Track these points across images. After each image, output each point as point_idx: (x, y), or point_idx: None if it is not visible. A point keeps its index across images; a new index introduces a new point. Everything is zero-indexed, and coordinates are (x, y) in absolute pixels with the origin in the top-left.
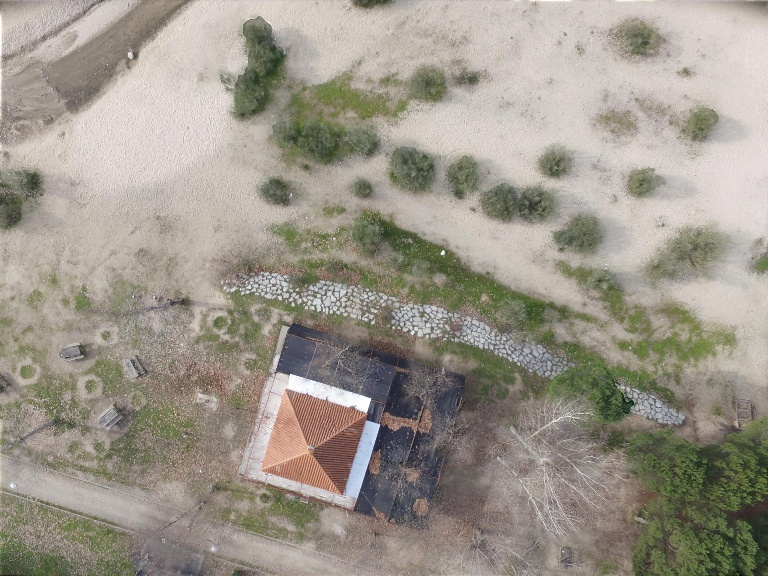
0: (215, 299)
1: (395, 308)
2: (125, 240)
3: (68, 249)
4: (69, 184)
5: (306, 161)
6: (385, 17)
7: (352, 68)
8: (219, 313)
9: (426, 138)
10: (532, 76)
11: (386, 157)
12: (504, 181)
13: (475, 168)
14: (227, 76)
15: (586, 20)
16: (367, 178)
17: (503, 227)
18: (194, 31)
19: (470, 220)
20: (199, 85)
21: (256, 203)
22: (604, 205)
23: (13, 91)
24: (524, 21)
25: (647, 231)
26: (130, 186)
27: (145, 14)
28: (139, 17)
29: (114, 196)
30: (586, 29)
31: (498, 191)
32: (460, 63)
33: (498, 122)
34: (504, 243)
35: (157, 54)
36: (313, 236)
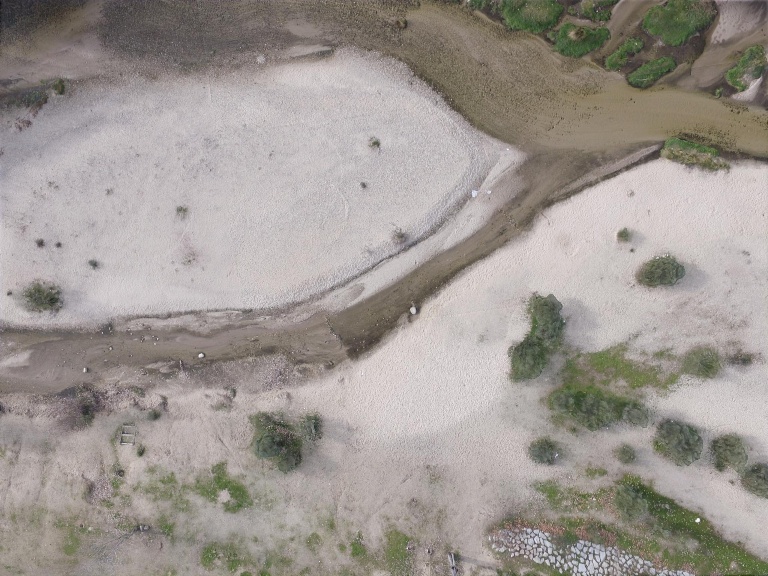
0: (484, 556)
1: (652, 575)
2: (398, 488)
3: (344, 494)
4: (346, 429)
5: (574, 424)
6: (667, 296)
7: (628, 340)
8: (489, 572)
9: (693, 411)
10: None
11: (652, 426)
12: (765, 458)
13: None
14: (507, 339)
15: None
16: (631, 445)
17: (759, 501)
18: (478, 294)
19: (728, 492)
20: (479, 346)
21: (522, 460)
22: None
23: (298, 335)
24: None
25: None
26: (404, 435)
27: (430, 272)
28: (424, 274)
29: (388, 443)
30: None
31: (766, 475)
32: (736, 345)
33: (766, 402)
34: (759, 516)
35: (440, 313)
36: (574, 495)
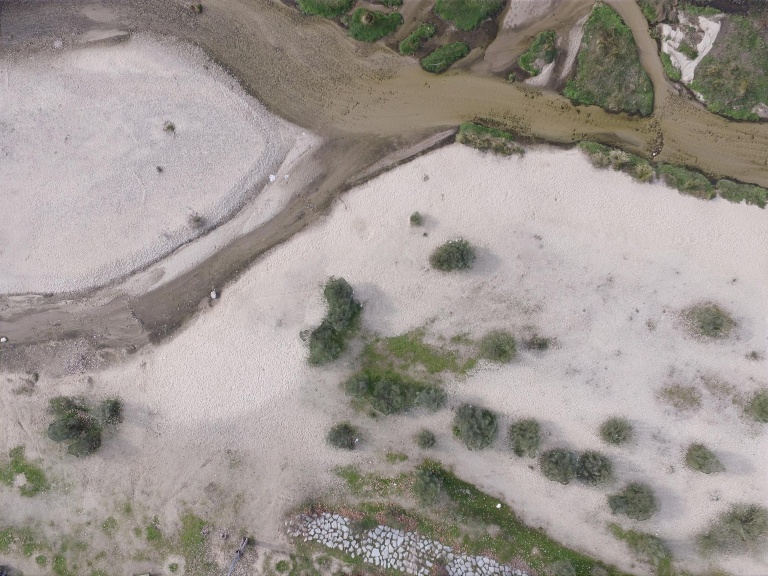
0: (279, 541)
1: (449, 561)
2: (197, 473)
3: (143, 478)
4: (147, 413)
5: (374, 409)
6: (462, 281)
7: (425, 325)
8: (282, 557)
9: (491, 396)
10: (601, 347)
11: (451, 411)
12: (564, 443)
13: (537, 431)
14: (304, 324)
15: (659, 299)
16: (431, 429)
17: (559, 487)
18: (276, 278)
19: (528, 477)
20: (277, 330)
21: (323, 445)
22: (661, 475)
23: (100, 320)
24: (598, 295)
25: (701, 503)
26: (204, 420)
27: (230, 256)
28: (224, 258)
29: (189, 428)
30: (658, 308)
31: (559, 460)
32: (531, 329)
33: (563, 387)
34: (559, 502)
35: (239, 297)
36: (375, 480)
